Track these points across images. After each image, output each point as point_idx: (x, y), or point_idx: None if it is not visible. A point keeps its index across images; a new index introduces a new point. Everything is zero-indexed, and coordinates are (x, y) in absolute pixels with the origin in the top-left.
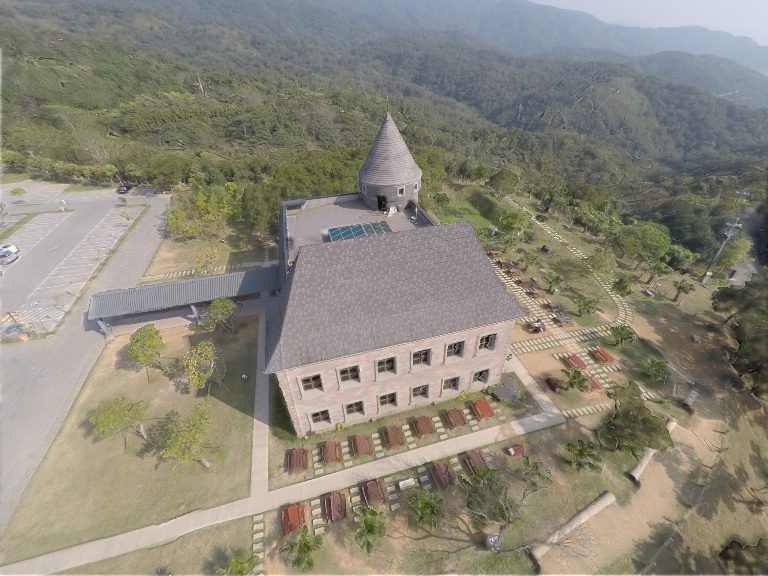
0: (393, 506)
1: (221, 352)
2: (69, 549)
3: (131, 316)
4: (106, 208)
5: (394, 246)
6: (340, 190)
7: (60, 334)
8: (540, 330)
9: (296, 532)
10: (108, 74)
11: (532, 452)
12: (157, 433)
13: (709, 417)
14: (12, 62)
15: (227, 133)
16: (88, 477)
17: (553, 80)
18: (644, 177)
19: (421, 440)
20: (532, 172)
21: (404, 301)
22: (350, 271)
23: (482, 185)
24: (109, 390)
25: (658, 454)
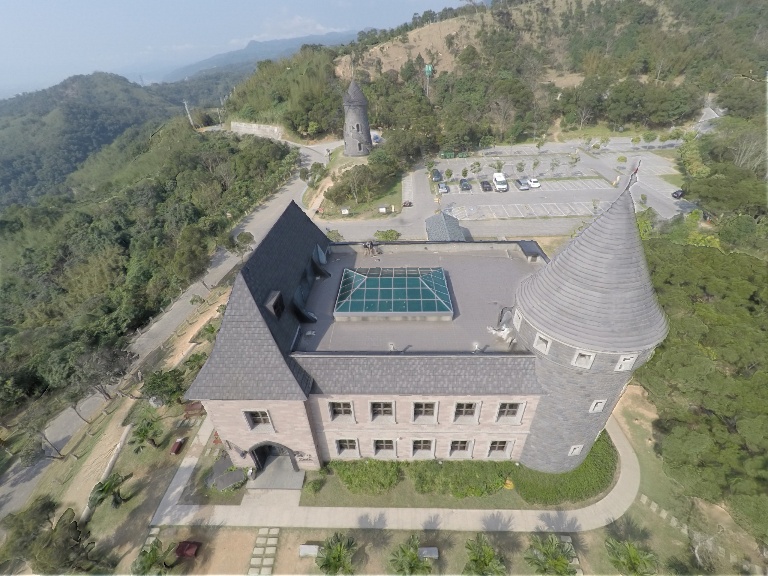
0: None
1: None
2: None
3: None
4: None
5: None
6: None
7: None
8: None
9: None
10: None
11: (165, 464)
12: None
13: None
14: None
15: None
16: None
17: None
18: None
19: None
20: None
21: None
22: None
23: None
24: None
25: None
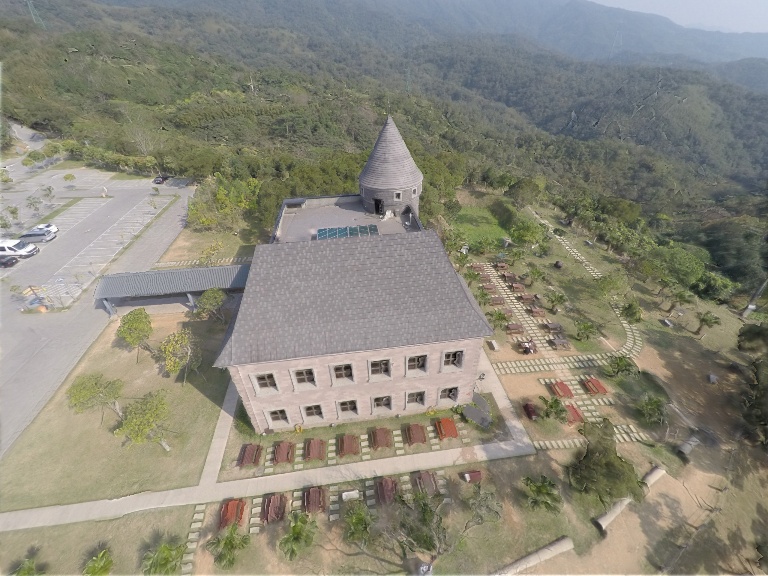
0: (332, 516)
1: (198, 341)
2: (30, 510)
3: (137, 299)
4: (141, 196)
5: (353, 251)
6: (349, 191)
7: (73, 310)
8: (530, 351)
9: None
10: (170, 73)
11: (491, 481)
12: None
13: (707, 470)
14: (89, 61)
15: (270, 131)
16: (63, 445)
17: (612, 87)
18: (707, 194)
19: (376, 452)
20: (578, 183)
21: (361, 308)
22: (306, 273)
23: None
24: (101, 366)
25: (635, 503)
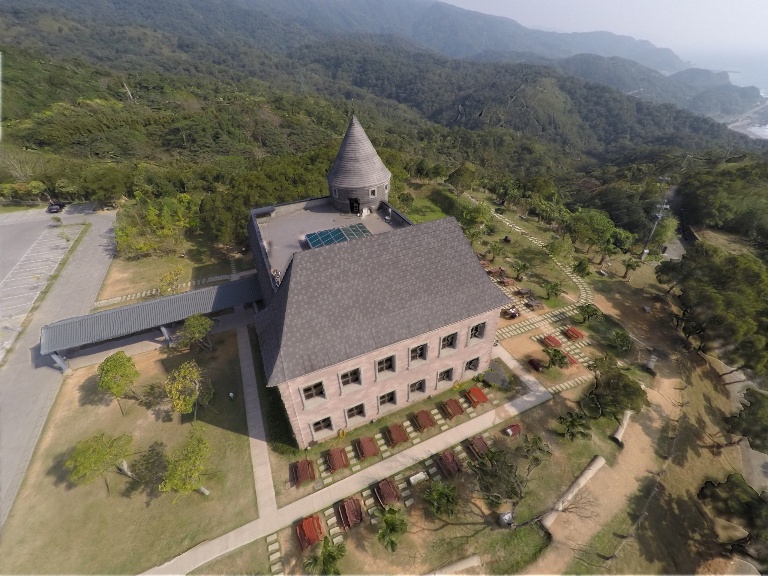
0: (407, 502)
1: (206, 372)
2: None
3: (89, 346)
4: (37, 230)
5: (386, 246)
6: (305, 195)
7: (4, 375)
8: (516, 316)
9: (314, 545)
10: (16, 81)
11: (527, 430)
12: (142, 468)
13: (669, 377)
14: None
15: (164, 142)
16: (68, 528)
17: (487, 81)
18: (575, 169)
19: (424, 434)
20: (477, 169)
21: (400, 299)
22: (346, 274)
23: (440, 183)
24: (76, 429)
25: (634, 415)
